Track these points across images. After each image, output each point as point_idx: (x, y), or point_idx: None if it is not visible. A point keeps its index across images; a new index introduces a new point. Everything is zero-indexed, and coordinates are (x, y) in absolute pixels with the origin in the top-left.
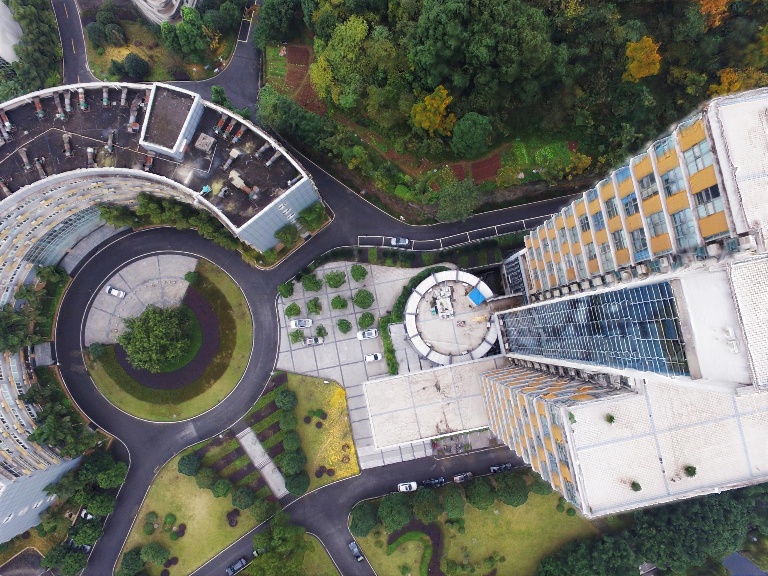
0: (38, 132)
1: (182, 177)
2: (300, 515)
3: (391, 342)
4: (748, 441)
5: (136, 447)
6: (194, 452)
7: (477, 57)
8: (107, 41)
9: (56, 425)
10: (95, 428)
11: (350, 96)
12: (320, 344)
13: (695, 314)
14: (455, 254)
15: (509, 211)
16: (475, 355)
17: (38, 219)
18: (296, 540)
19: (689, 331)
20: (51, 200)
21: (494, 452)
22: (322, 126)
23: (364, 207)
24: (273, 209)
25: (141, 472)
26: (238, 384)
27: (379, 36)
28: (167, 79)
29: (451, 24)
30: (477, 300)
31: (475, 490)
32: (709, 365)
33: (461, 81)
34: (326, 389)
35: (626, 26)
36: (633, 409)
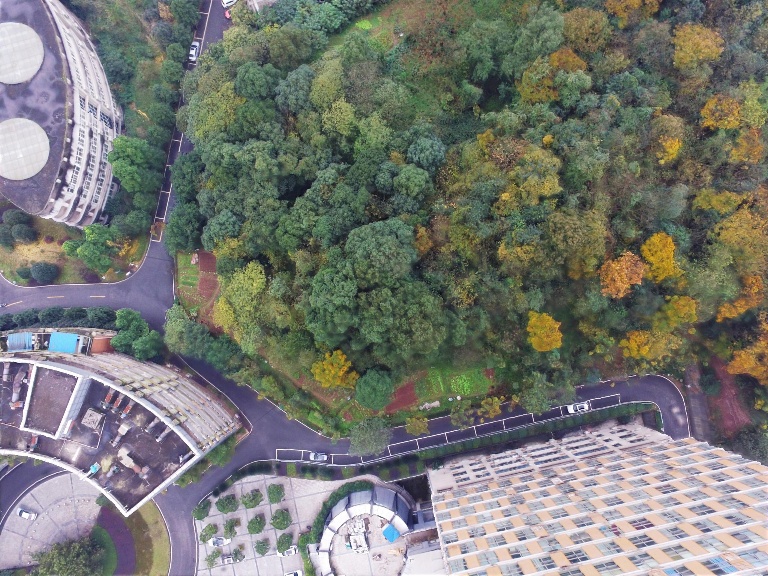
0: None
1: (70, 454)
2: None
3: (310, 562)
4: None
5: None
6: None
7: (370, 339)
8: (15, 241)
9: None
10: None
11: (250, 346)
12: (239, 561)
13: None
14: (375, 469)
15: (431, 423)
16: None
17: None
18: None
19: None
20: None
21: None
22: (229, 359)
23: (282, 418)
24: None
25: None
26: None
27: (276, 293)
28: (78, 282)
29: (338, 315)
30: (391, 538)
31: None
32: None
33: (359, 347)
34: None
35: (528, 295)
36: None
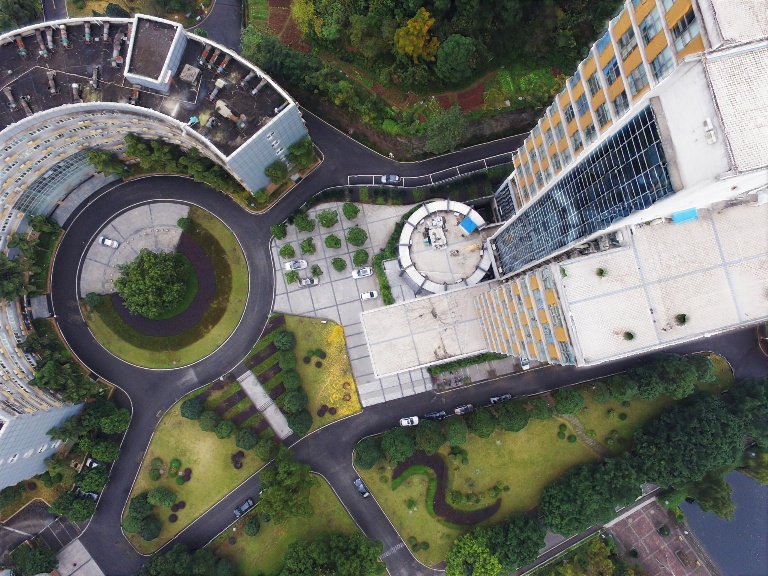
0: (22, 71)
1: (169, 110)
2: (304, 455)
3: (386, 278)
4: (735, 288)
5: (138, 395)
6: (196, 397)
7: None
8: None
9: (56, 371)
10: (96, 378)
11: (333, 26)
12: (316, 285)
13: (675, 125)
14: (446, 188)
15: (497, 143)
16: (470, 282)
17: (27, 163)
18: (301, 475)
19: (670, 146)
20: (39, 141)
21: (493, 383)
22: (307, 62)
23: (353, 147)
24: (261, 138)
25: (144, 419)
26: (236, 328)
27: None
28: None
29: None
30: (469, 228)
31: (476, 417)
32: (690, 173)
33: (442, 2)
34: (324, 329)
35: None
36: (622, 263)
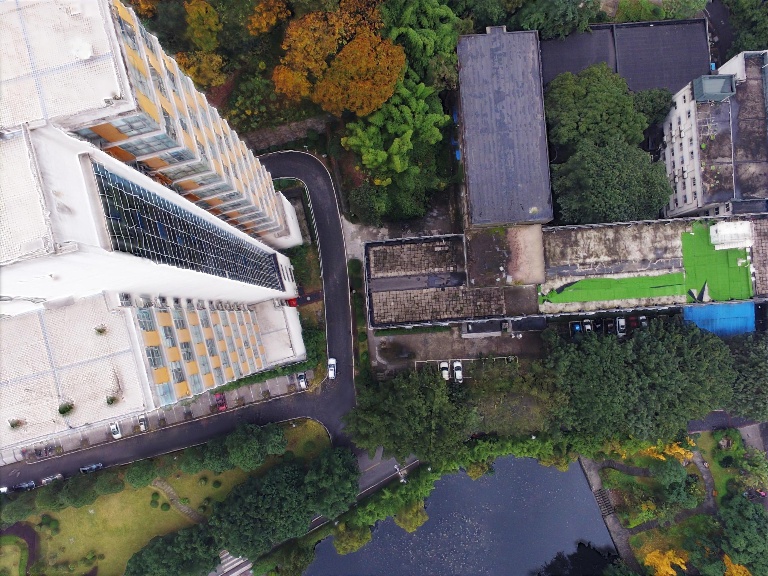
0: None
1: None
2: None
3: None
4: None
5: None
6: None
7: None
8: None
9: None
10: None
11: None
12: None
13: None
14: None
15: None
16: None
17: None
18: None
19: None
20: None
21: (85, 453)
22: None
23: None
24: None
25: None
26: None
27: None
28: None
29: None
30: None
31: (38, 494)
32: None
33: None
34: None
35: None
36: None
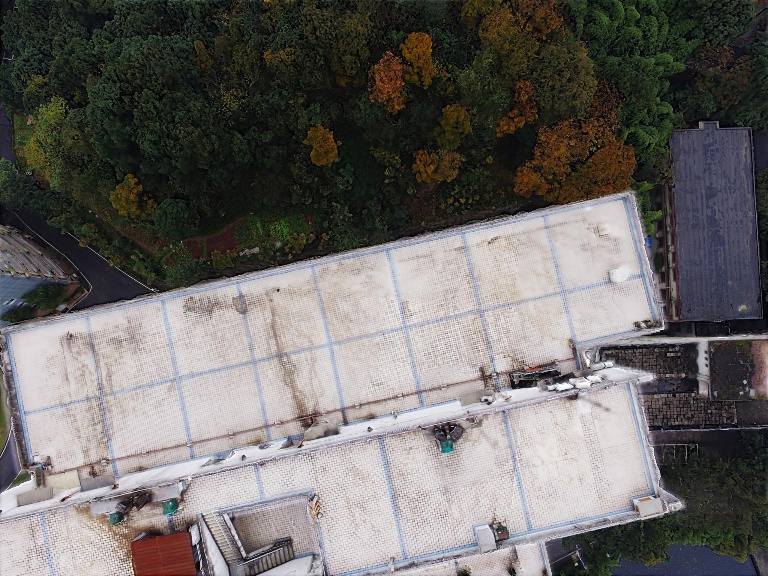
0: None
1: None
2: None
3: None
4: None
5: None
6: None
7: (145, 150)
8: None
9: None
10: None
11: (55, 181)
12: None
13: None
14: None
15: None
16: None
17: None
18: None
19: None
20: None
21: None
22: (49, 205)
23: (120, 278)
24: None
25: None
26: None
27: (72, 121)
28: None
29: (105, 121)
30: None
31: None
32: None
33: (149, 169)
34: None
35: (308, 111)
36: None
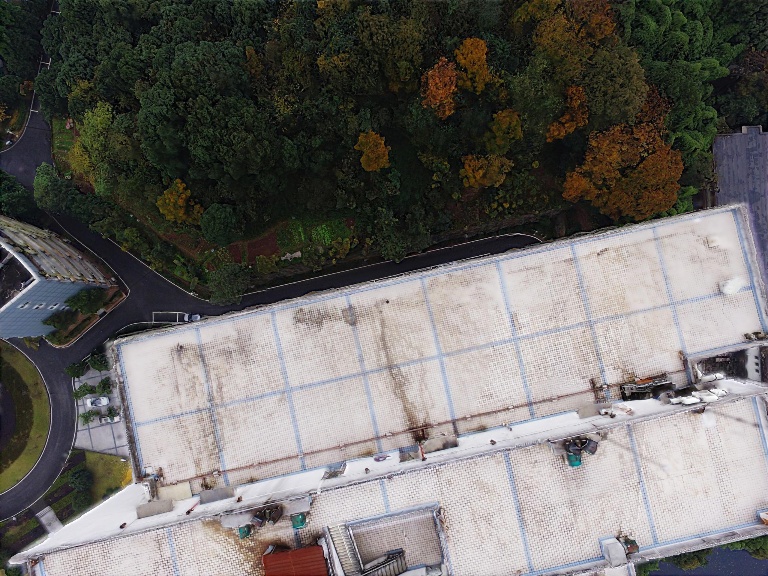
0: None
1: None
2: None
3: None
4: None
5: None
6: None
7: (197, 156)
8: None
9: None
10: None
11: (101, 185)
12: (117, 422)
13: None
14: None
15: (303, 284)
16: None
17: None
18: None
19: None
20: None
21: None
22: (91, 209)
23: (158, 282)
24: (9, 311)
25: None
26: (37, 463)
27: (119, 126)
28: None
29: (159, 126)
30: None
31: None
32: None
33: (197, 174)
34: (124, 467)
35: (358, 116)
36: None
